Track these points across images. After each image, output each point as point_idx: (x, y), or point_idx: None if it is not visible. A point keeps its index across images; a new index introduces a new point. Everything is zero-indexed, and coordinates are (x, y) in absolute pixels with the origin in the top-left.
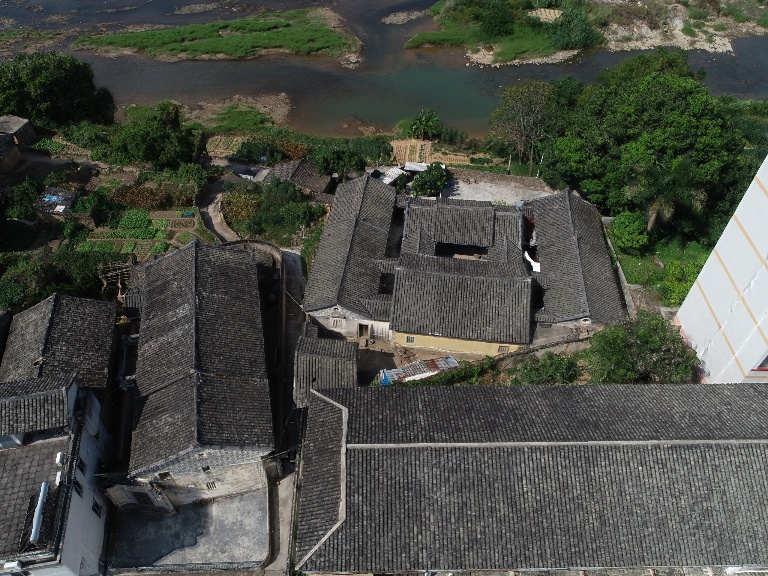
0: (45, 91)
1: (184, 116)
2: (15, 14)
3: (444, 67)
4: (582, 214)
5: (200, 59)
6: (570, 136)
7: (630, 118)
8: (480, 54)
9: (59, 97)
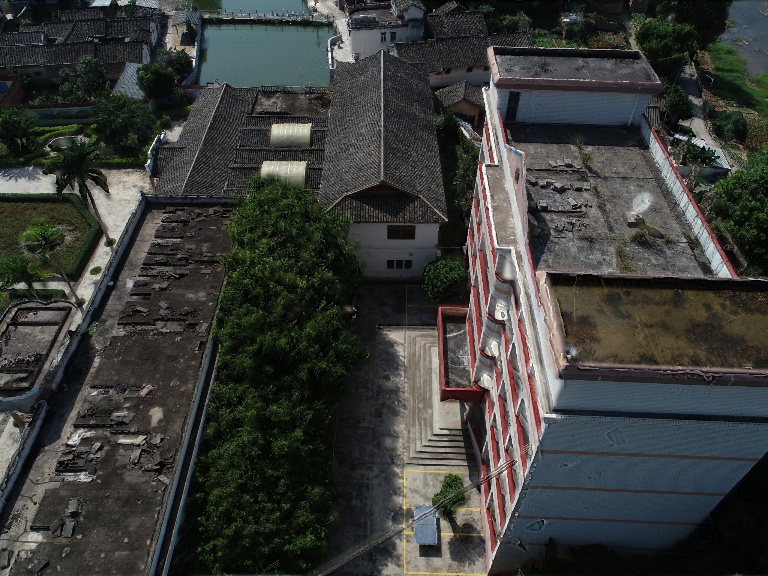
0: None
1: None
2: None
3: None
4: None
5: None
6: None
7: None
8: None
9: (690, 6)
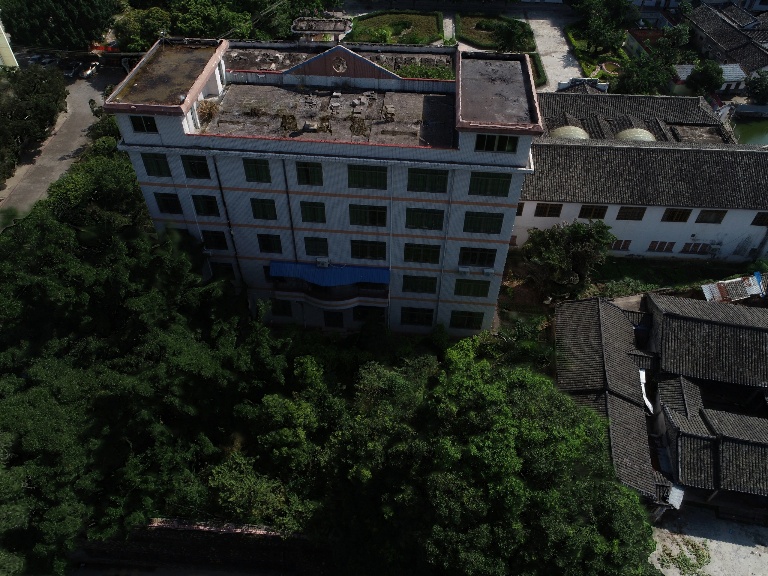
0: None
1: None
2: None
3: None
4: None
5: None
6: None
7: None
8: None
9: None
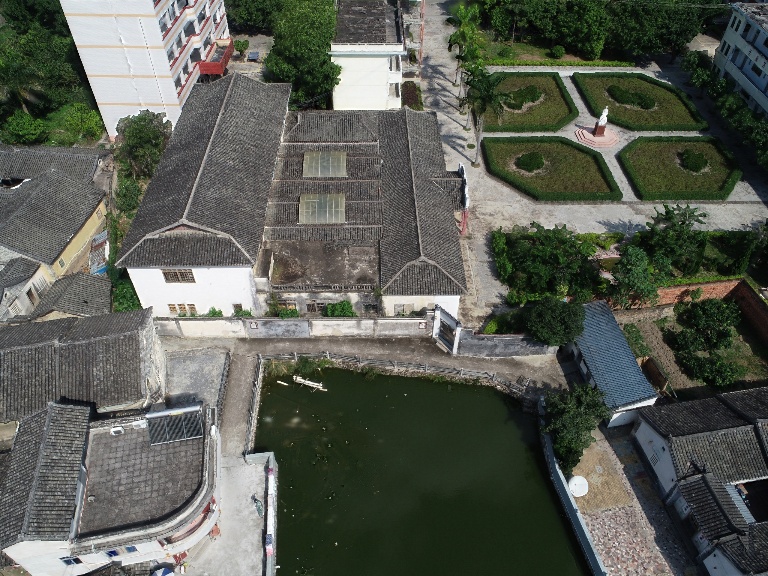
0: None
1: None
2: None
3: None
4: None
5: None
6: None
7: None
8: None
9: None
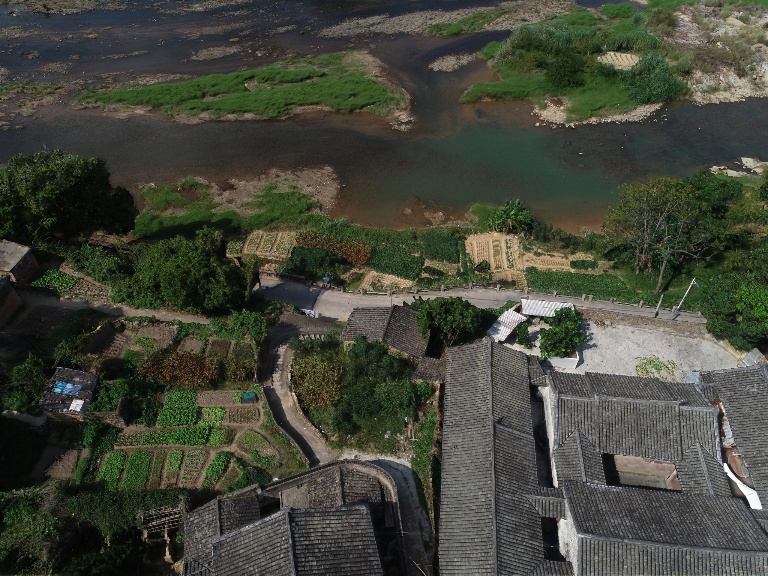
0: (50, 205)
1: (213, 200)
2: (7, 61)
3: (510, 128)
4: None
5: (225, 120)
6: None
7: None
8: (549, 110)
9: (67, 207)
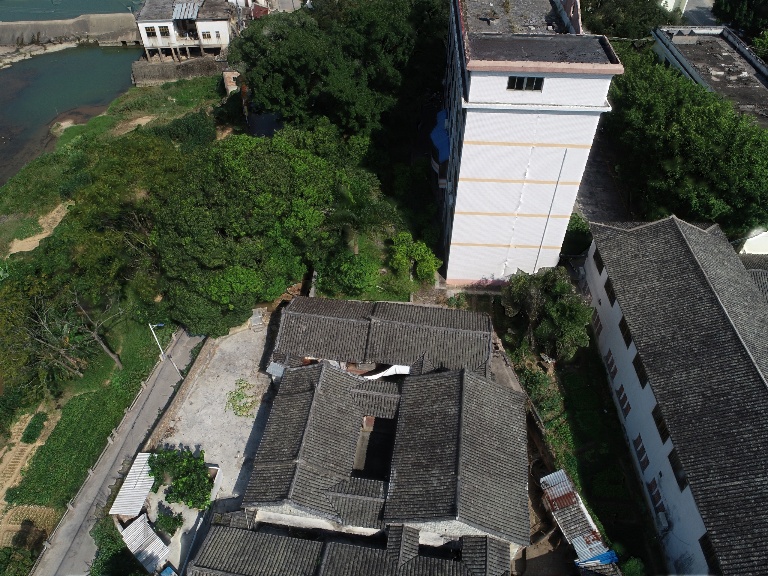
0: None
1: None
2: None
3: None
4: (319, 308)
5: None
6: (224, 274)
7: (272, 203)
8: None
9: None
